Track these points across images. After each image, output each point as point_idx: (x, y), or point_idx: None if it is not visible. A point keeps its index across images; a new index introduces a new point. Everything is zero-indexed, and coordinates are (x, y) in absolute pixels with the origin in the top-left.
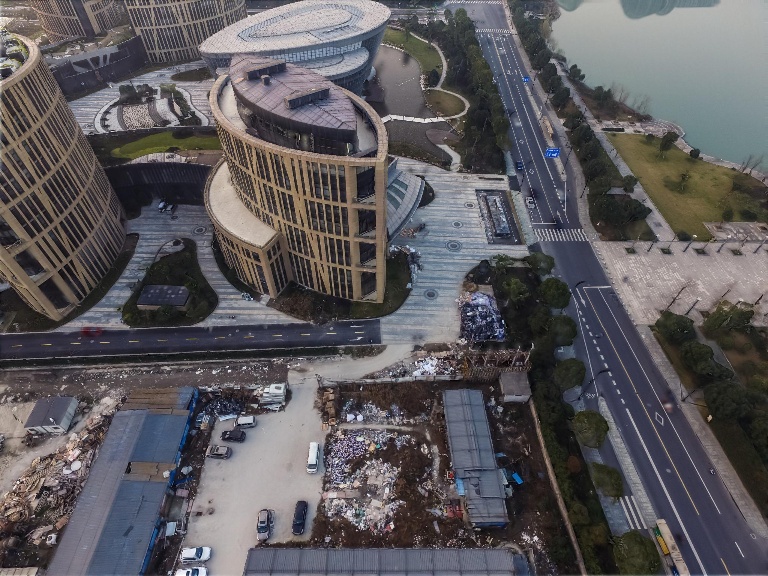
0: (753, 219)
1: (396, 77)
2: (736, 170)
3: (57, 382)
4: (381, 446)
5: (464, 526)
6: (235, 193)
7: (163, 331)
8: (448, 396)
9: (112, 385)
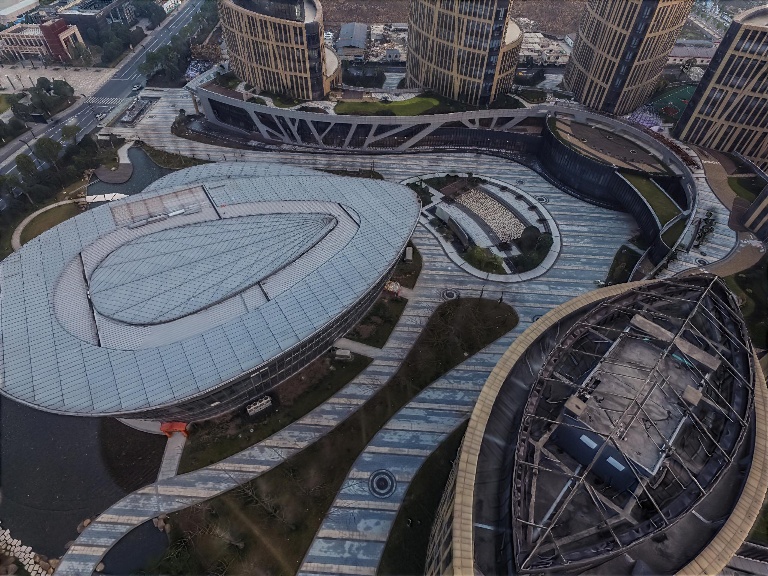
0: None
1: None
2: None
3: None
4: None
5: None
6: None
7: None
8: None
9: None
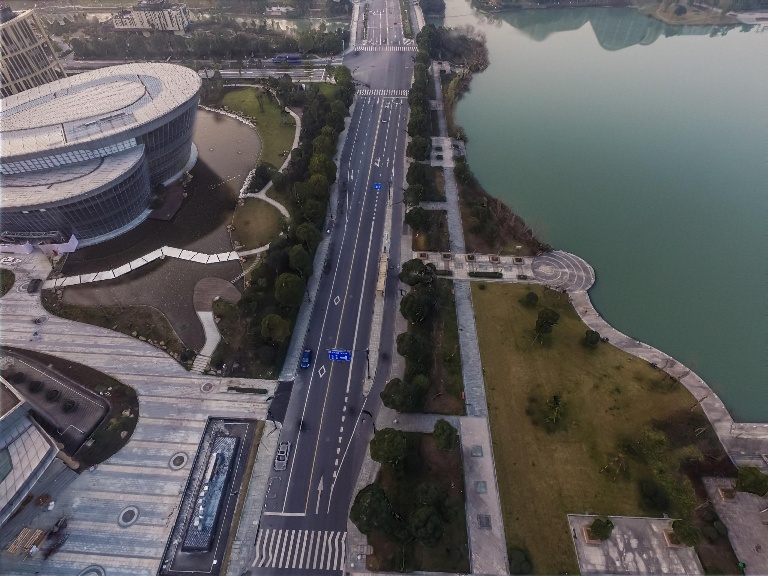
0: (660, 509)
1: (217, 173)
2: (657, 368)
3: None
4: None
5: None
6: None
7: None
8: None
9: None
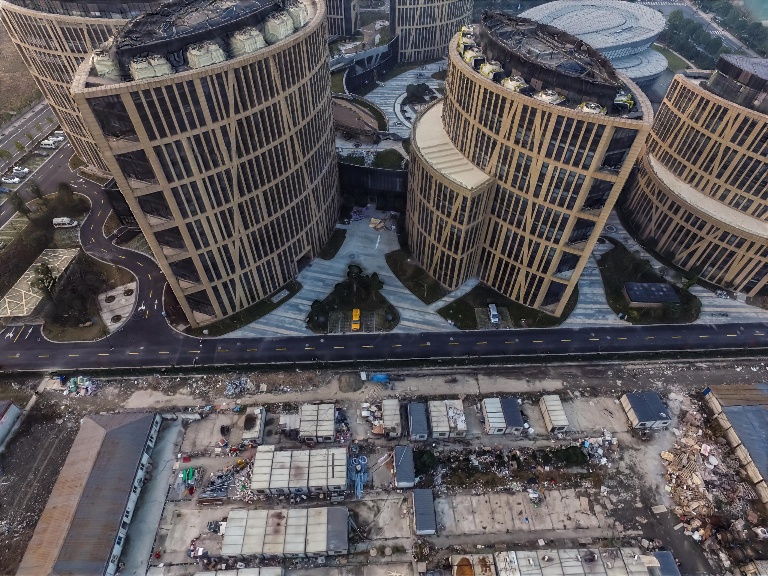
0: None
1: None
2: None
3: (607, 377)
4: None
5: None
6: (698, 192)
7: (669, 328)
8: None
9: (665, 381)
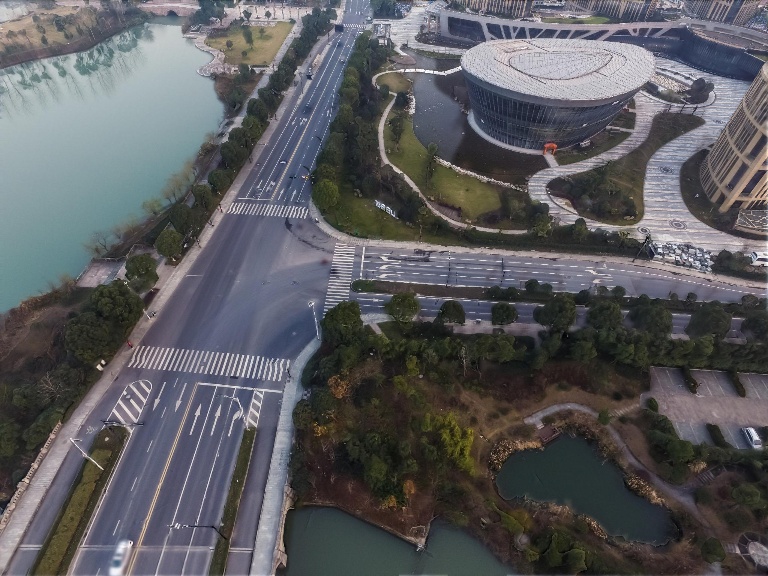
0: None
1: (443, 114)
2: None
3: None
4: None
5: None
6: None
7: None
8: None
9: None
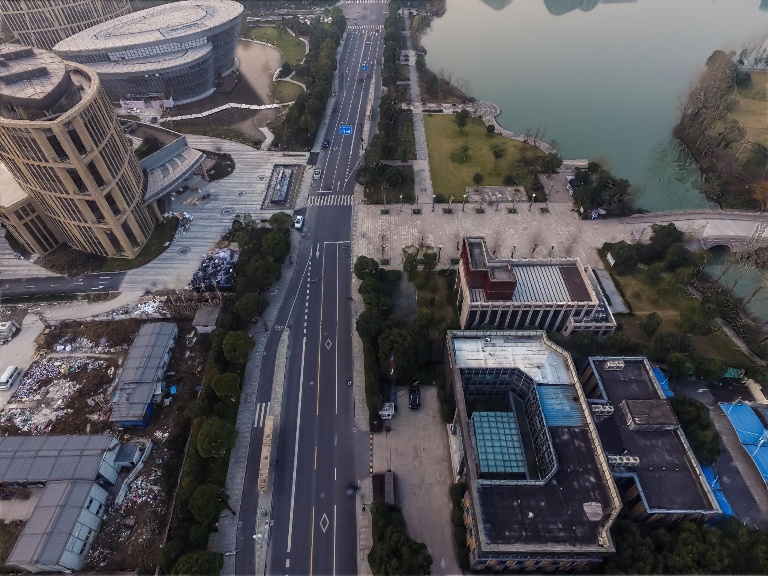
0: (513, 183)
1: (255, 70)
2: (527, 143)
3: None
4: (75, 369)
5: (112, 427)
6: None
7: None
8: (144, 328)
9: None
